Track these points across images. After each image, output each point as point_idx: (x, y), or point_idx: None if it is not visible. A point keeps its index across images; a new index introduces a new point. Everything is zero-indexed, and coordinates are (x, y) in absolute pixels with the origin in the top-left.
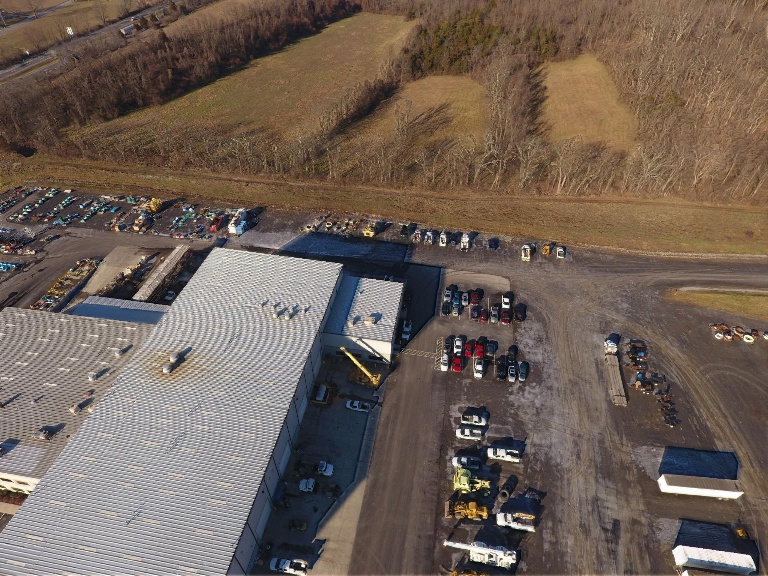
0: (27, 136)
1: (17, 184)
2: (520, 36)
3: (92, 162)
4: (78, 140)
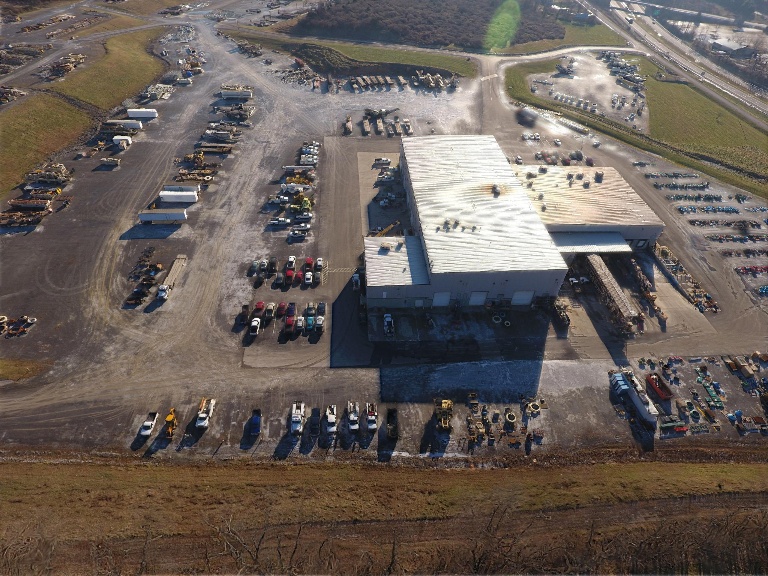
0: None
1: None
2: None
3: None
4: None
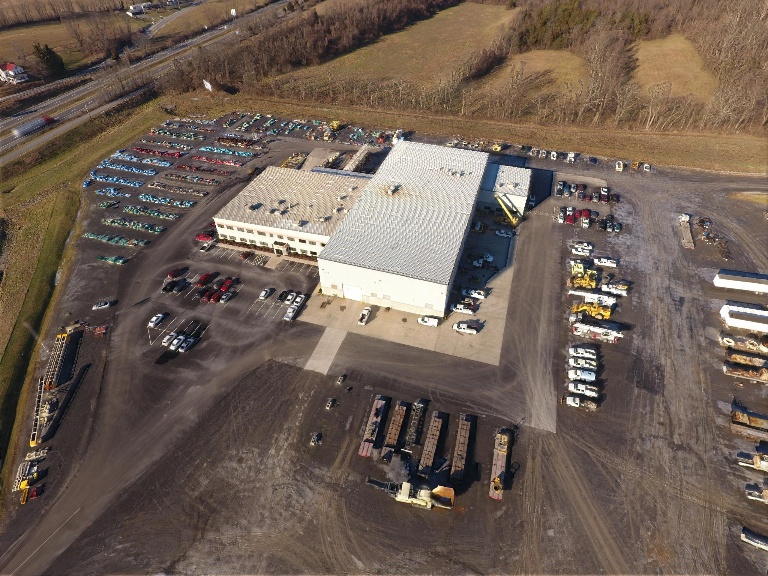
0: (233, 80)
1: (231, 111)
2: (616, 18)
3: (280, 99)
4: (272, 82)
